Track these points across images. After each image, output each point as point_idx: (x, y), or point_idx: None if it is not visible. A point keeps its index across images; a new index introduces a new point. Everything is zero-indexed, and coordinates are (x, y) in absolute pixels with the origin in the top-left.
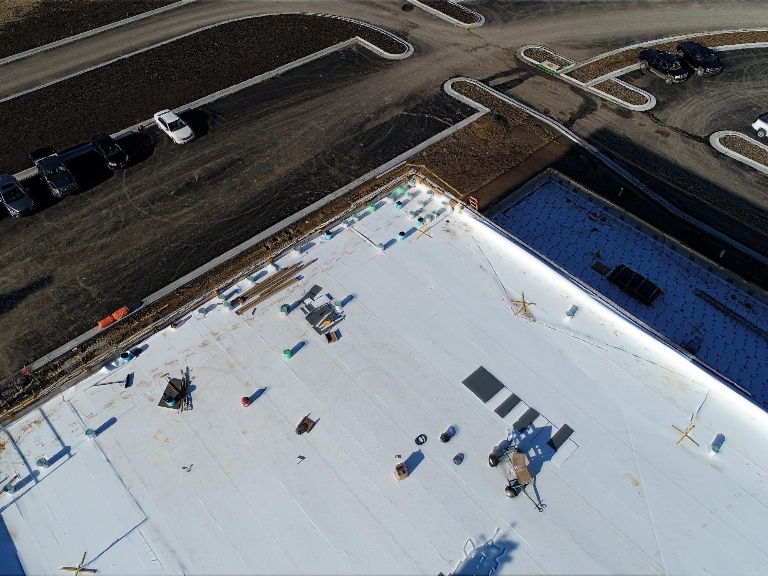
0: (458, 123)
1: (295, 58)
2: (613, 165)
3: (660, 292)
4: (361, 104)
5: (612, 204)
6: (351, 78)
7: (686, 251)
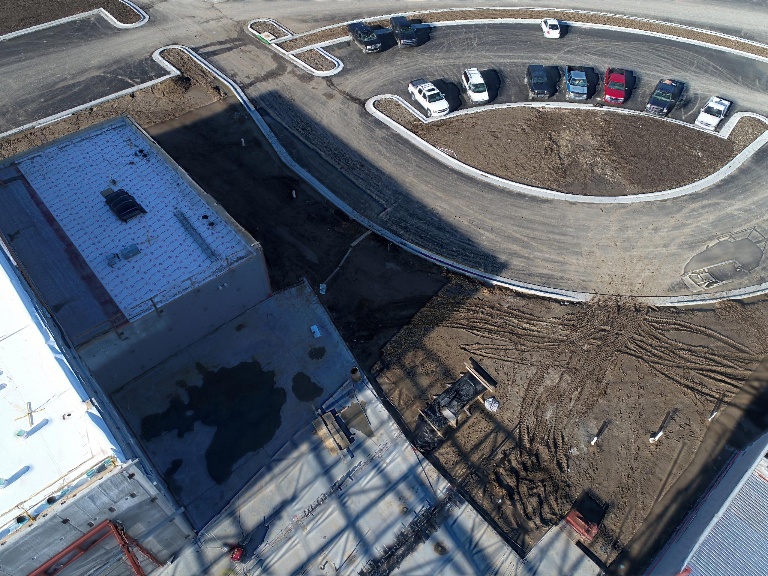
0: (143, 83)
1: (30, 25)
2: (260, 121)
3: (140, 211)
4: (66, 66)
5: (155, 142)
6: (72, 44)
7: (186, 180)
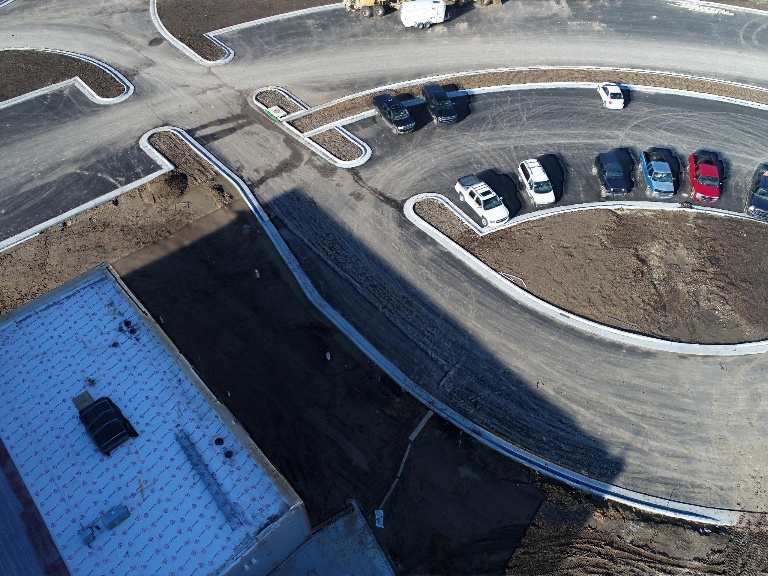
0: (129, 184)
1: None
2: (276, 237)
3: (128, 436)
4: (33, 160)
5: (146, 312)
6: (41, 128)
7: (191, 378)
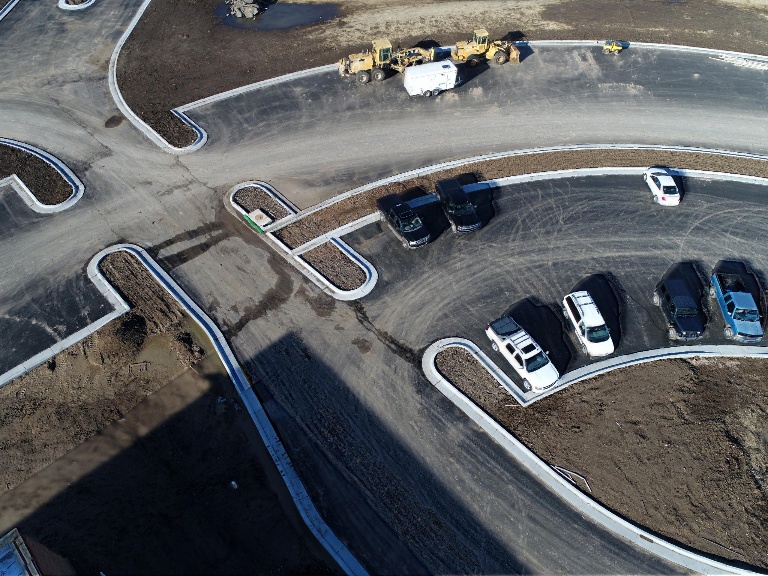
0: (70, 336)
1: None
2: (259, 416)
3: None
4: None
5: None
6: None
7: None
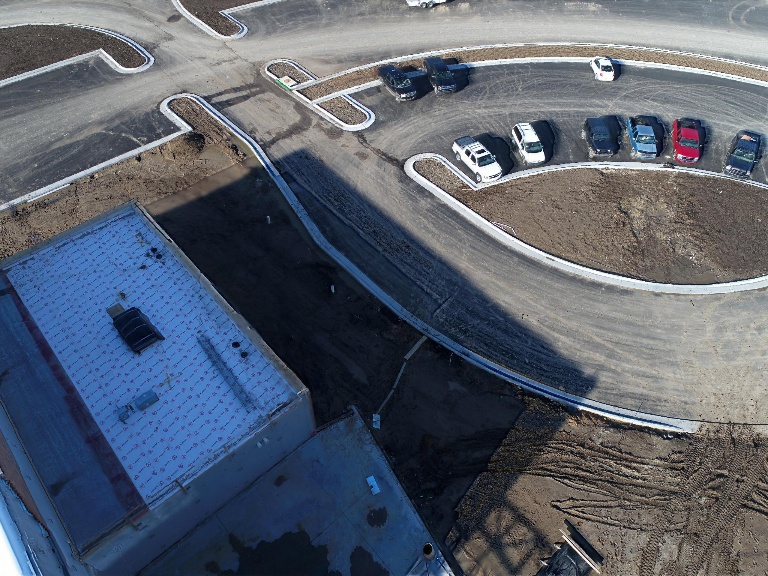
0: (150, 143)
1: (21, 72)
2: (286, 190)
3: (157, 338)
4: (62, 121)
5: (171, 240)
6: (69, 93)
7: (211, 293)
